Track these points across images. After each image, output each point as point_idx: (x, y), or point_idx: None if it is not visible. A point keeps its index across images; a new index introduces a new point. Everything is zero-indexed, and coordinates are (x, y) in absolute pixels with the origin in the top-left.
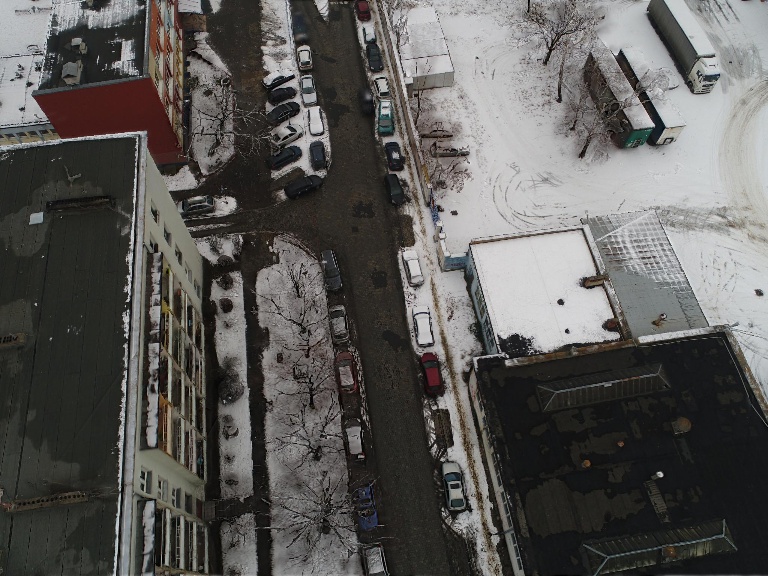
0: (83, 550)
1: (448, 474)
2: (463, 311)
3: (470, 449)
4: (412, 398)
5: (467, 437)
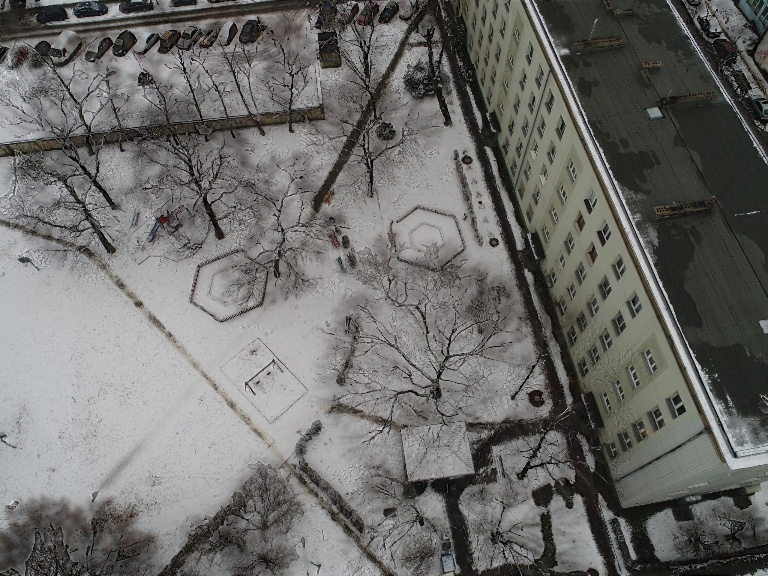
0: (651, 4)
1: (757, 99)
2: (736, 17)
3: (765, 90)
4: (713, 65)
5: (761, 84)
